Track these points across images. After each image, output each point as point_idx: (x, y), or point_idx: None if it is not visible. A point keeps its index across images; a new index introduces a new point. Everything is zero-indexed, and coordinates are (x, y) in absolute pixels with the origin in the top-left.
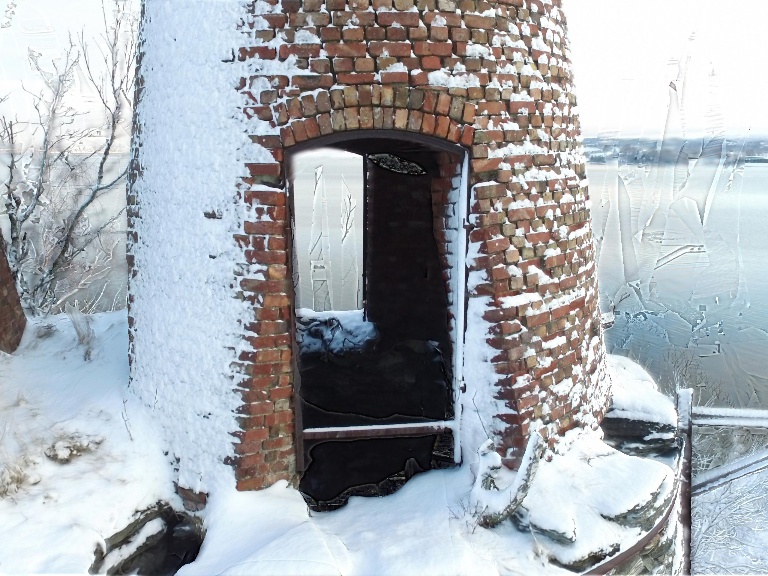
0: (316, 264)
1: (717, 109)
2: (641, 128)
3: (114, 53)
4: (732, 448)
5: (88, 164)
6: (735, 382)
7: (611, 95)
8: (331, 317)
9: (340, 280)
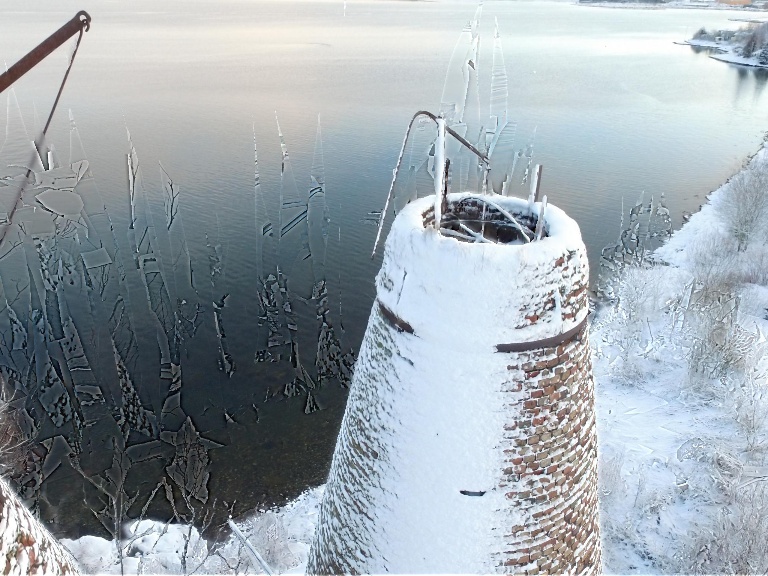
0: (145, 258)
1: (501, 69)
2: (441, 91)
3: (185, 476)
4: None
5: None
6: None
7: (446, 139)
8: None
9: (171, 266)
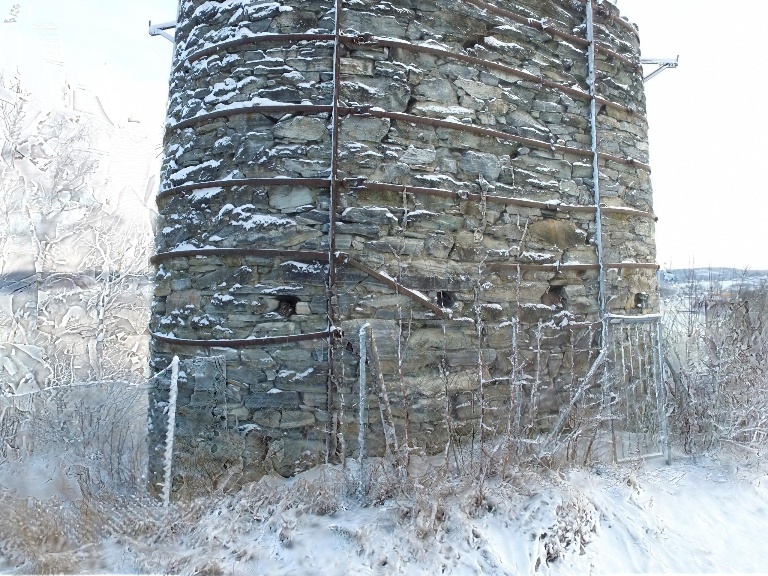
0: None
1: None
2: None
3: None
4: None
5: (93, 129)
6: None
7: None
8: None
9: None
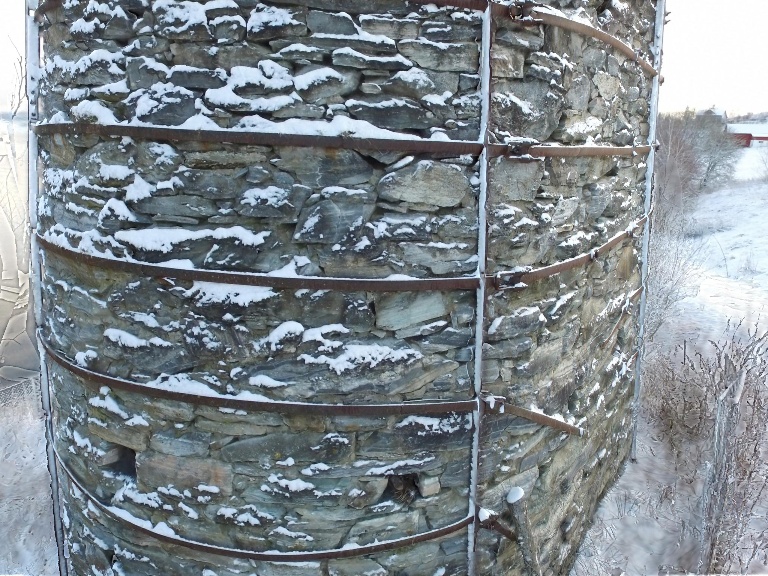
0: None
1: None
2: None
3: None
4: None
5: None
6: None
7: None
8: None
9: (17, 159)
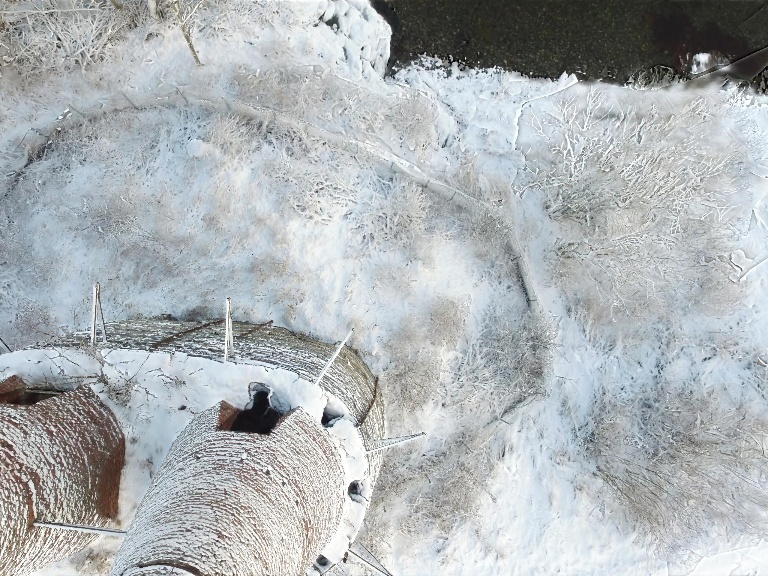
0: None
1: None
2: None
3: None
4: (698, 238)
5: None
6: (765, 196)
7: None
8: (269, 400)
9: None
